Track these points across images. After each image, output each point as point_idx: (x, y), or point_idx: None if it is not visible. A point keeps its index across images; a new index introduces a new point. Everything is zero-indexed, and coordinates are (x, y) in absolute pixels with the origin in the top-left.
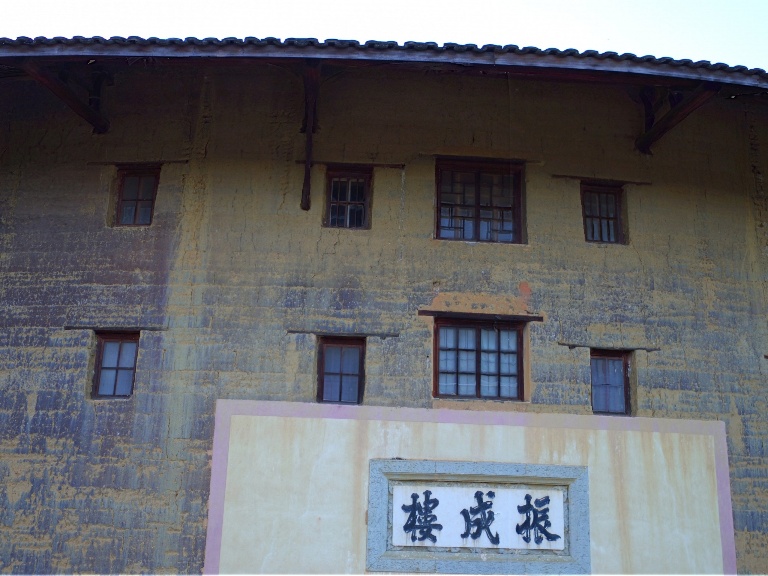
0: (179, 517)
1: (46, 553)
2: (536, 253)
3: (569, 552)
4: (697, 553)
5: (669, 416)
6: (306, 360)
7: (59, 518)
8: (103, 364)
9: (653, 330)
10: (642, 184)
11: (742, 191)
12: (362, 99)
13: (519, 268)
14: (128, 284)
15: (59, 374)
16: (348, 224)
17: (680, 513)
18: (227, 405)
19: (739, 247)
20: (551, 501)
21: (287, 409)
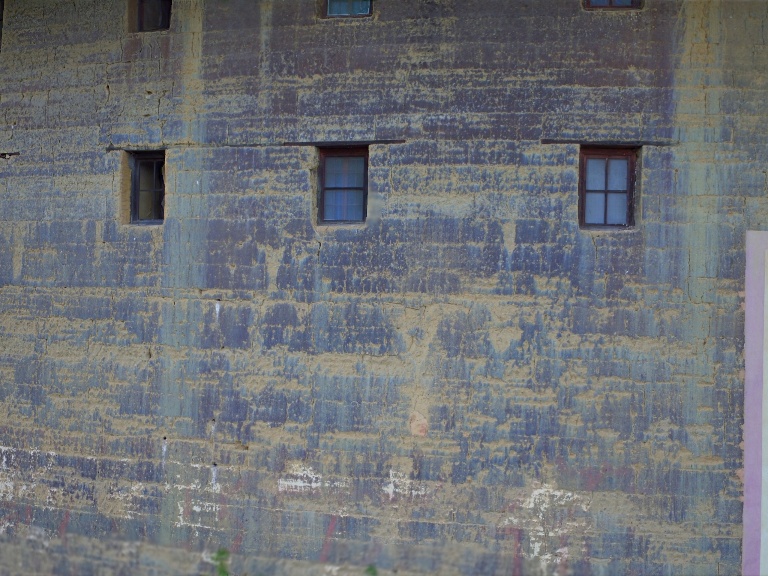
0: (710, 368)
1: (550, 409)
2: None
3: None
4: None
5: None
6: None
7: (562, 370)
8: (587, 186)
9: None
10: None
11: None
12: None
13: None
14: (621, 86)
15: (542, 199)
16: None
17: None
18: (760, 238)
19: None
20: None
21: None
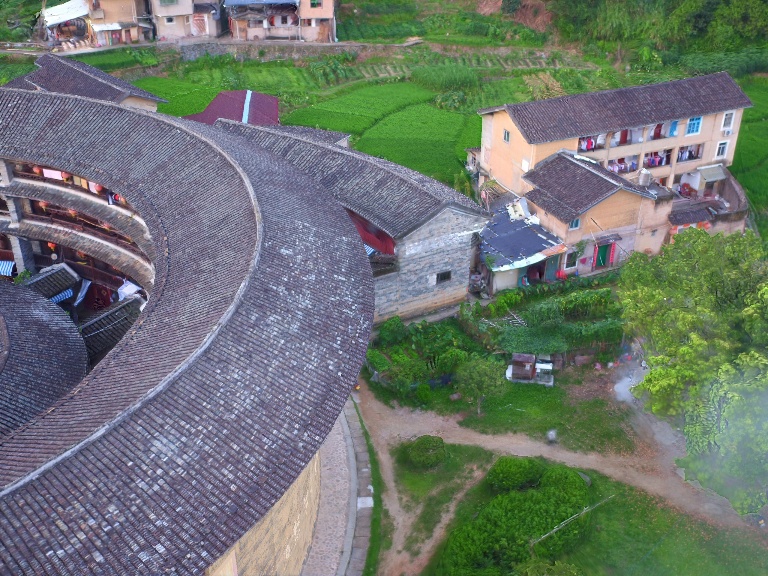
0: None
1: None
2: None
3: None
4: None
5: None
6: None
7: None
8: None
9: None
10: None
11: None
12: None
13: None
14: None
15: None
16: None
17: None
18: None
19: None
20: None
21: None
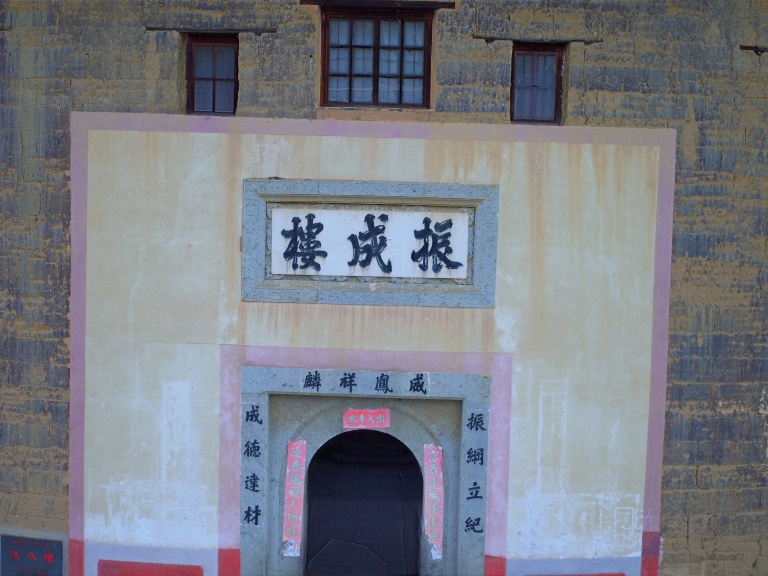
0: (41, 243)
1: None
2: None
3: (472, 281)
4: (623, 282)
5: (606, 124)
6: (168, 63)
7: None
8: None
9: (596, 16)
10: None
11: None
12: None
13: None
14: None
15: None
16: None
17: (607, 237)
18: (82, 118)
19: None
20: (454, 225)
21: (149, 122)
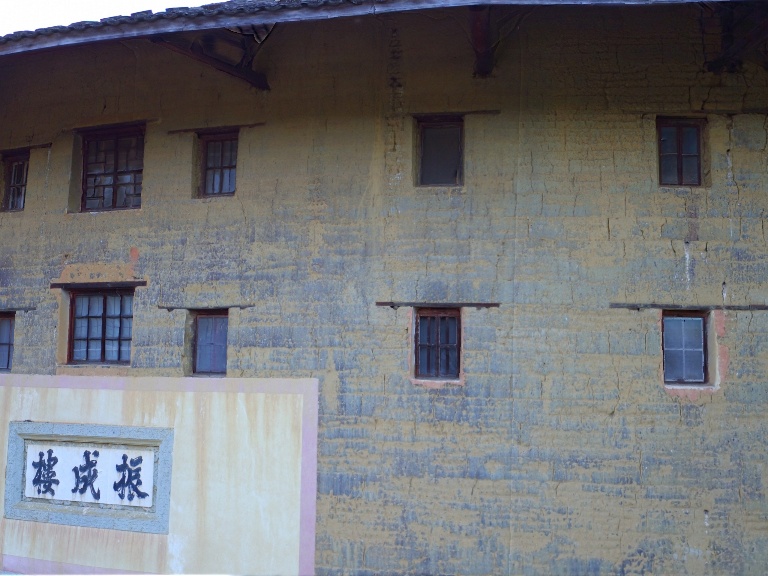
0: None
1: None
2: (146, 217)
3: None
4: (272, 516)
5: (257, 375)
6: None
7: None
8: None
9: (249, 285)
10: (255, 126)
11: (372, 113)
12: (26, 84)
13: (131, 234)
14: None
15: None
16: (22, 205)
17: (258, 475)
18: None
19: (360, 180)
20: (143, 461)
21: None
